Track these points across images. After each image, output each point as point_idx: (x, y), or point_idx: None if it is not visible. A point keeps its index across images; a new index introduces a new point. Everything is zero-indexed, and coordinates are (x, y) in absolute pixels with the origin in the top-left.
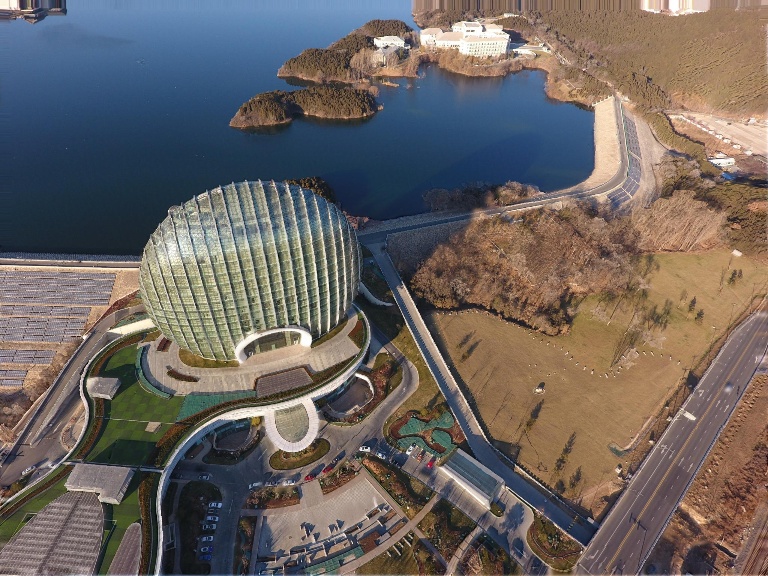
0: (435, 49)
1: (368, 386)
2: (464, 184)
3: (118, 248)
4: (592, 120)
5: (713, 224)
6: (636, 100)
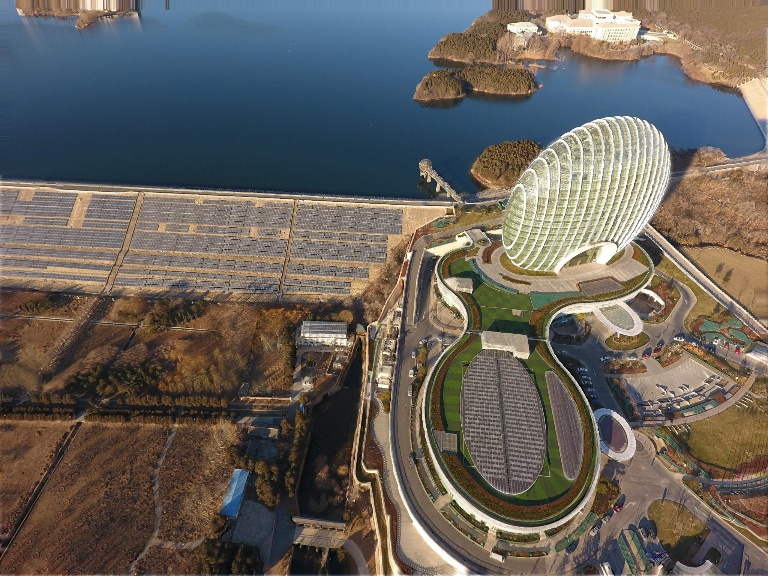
0: (565, 35)
1: (648, 300)
2: None
3: (385, 192)
4: (741, 100)
5: None
6: None
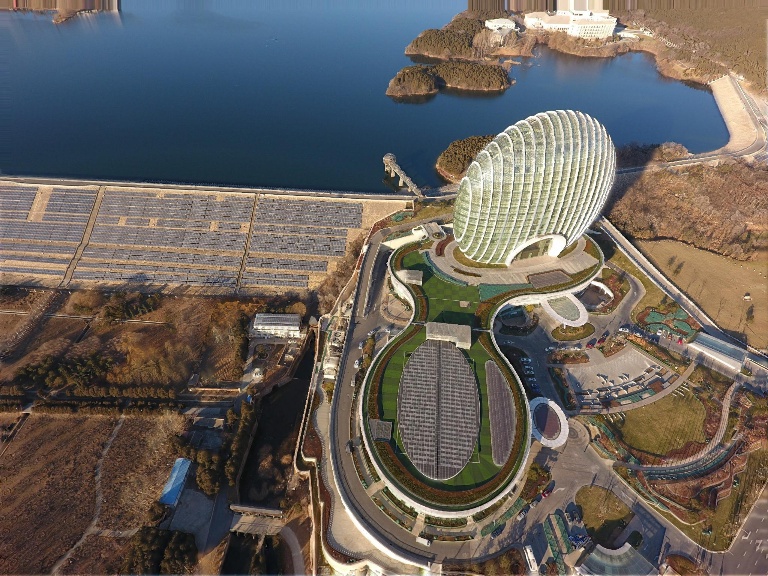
0: (542, 32)
1: (599, 292)
2: (626, 143)
3: (348, 186)
4: (711, 96)
5: None
6: (751, 79)
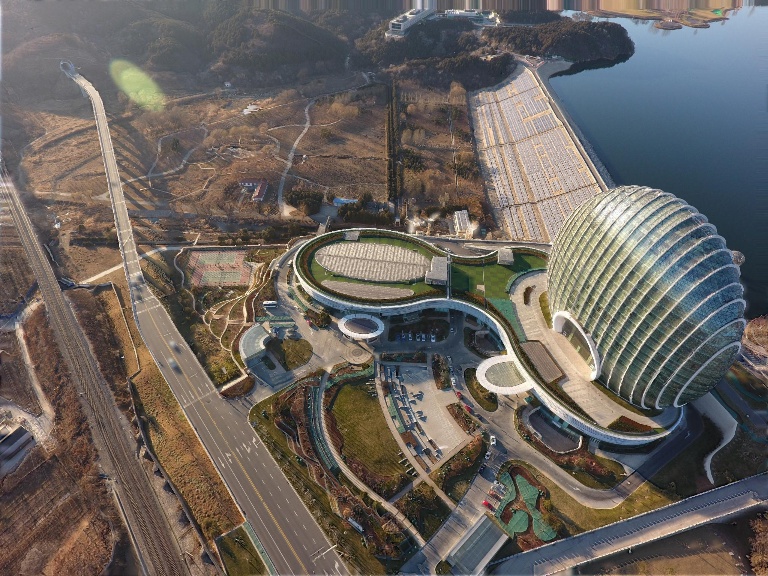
0: None
1: None
2: None
3: None
4: None
5: None
6: None
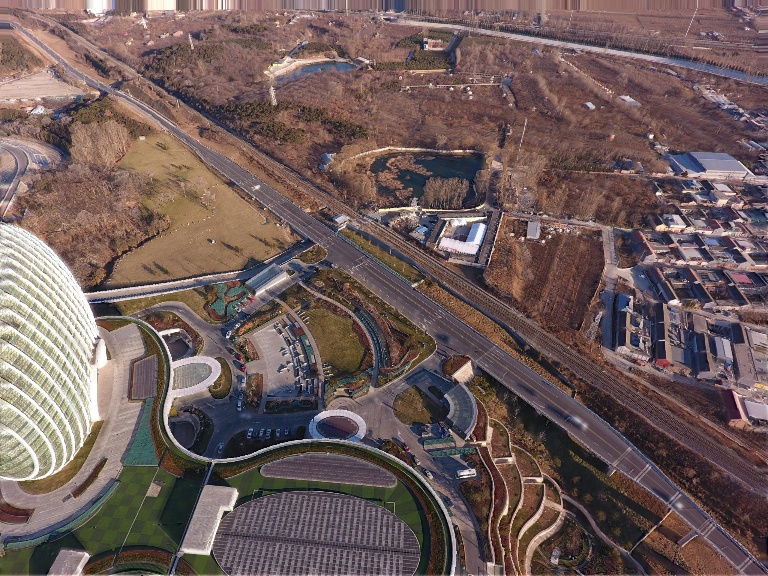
0: None
1: None
2: None
3: None
4: None
5: (120, 126)
6: None
